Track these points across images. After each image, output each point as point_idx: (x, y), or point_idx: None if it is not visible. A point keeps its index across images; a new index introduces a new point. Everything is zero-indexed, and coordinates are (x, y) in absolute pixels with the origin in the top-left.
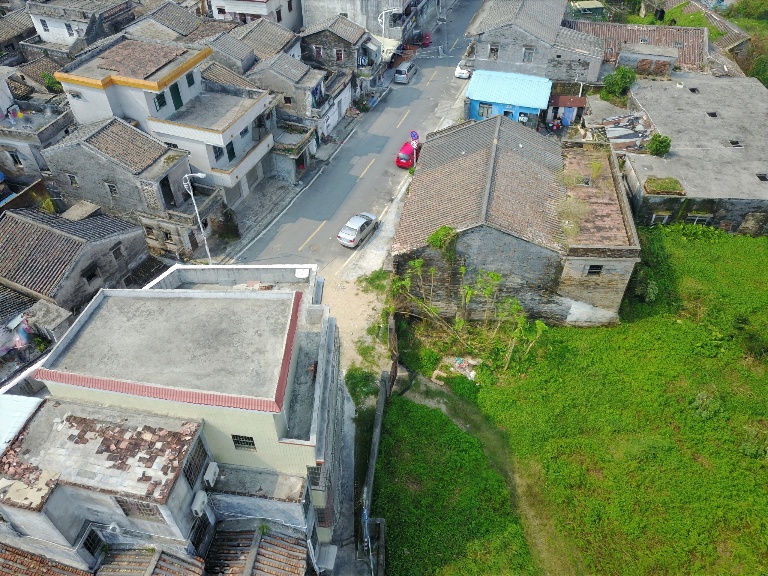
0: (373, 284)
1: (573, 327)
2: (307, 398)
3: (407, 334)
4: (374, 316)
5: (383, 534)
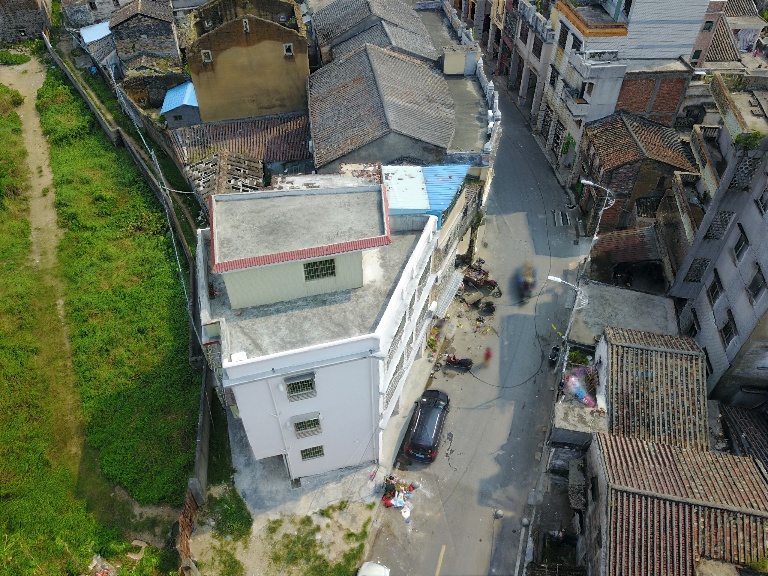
0: None
1: None
2: (216, 274)
3: None
4: None
5: (190, 350)
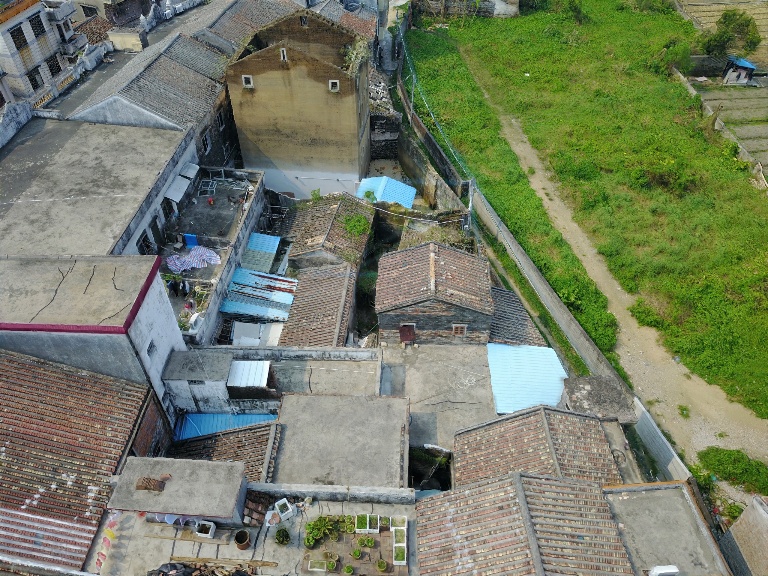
0: (401, 7)
1: (497, 18)
2: None
3: (417, 16)
4: (401, 15)
5: None
